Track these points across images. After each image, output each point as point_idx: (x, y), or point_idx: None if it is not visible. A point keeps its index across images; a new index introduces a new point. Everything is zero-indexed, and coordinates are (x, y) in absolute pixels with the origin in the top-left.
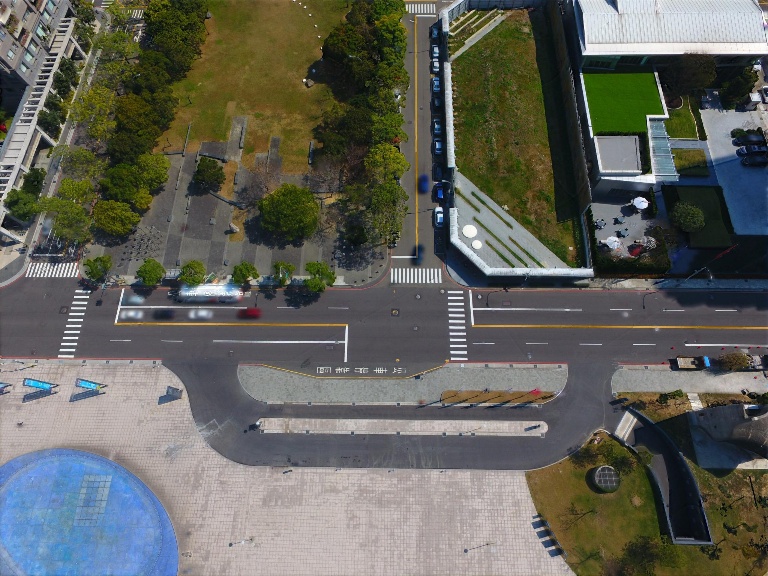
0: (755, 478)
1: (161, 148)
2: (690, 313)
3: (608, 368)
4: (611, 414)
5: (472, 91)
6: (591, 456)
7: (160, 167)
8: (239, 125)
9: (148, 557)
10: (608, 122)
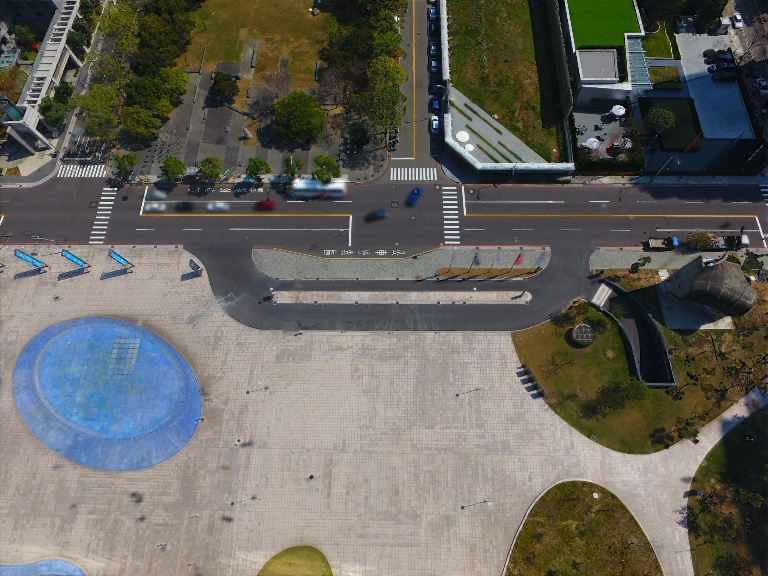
0: (716, 337)
1: (179, 68)
2: (662, 204)
3: (587, 249)
4: (589, 286)
5: (465, 18)
6: (570, 319)
7: (179, 80)
8: (251, 48)
9: (174, 403)
10: (589, 39)
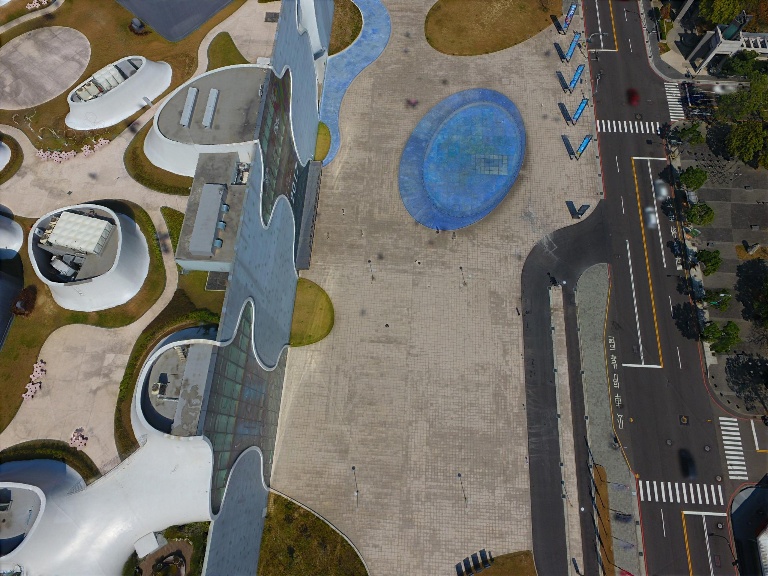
0: None
1: None
2: None
3: None
4: None
5: None
6: None
7: None
8: None
9: (451, 209)
10: None
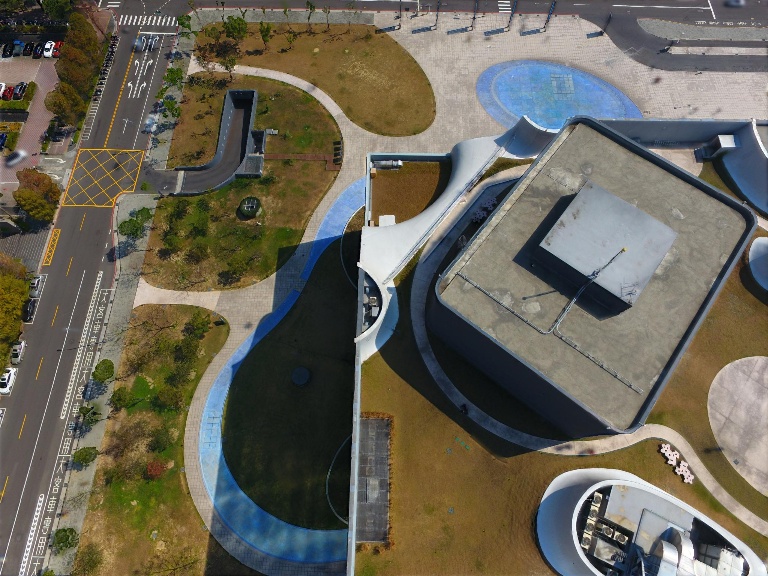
0: None
1: None
2: None
3: None
4: None
5: None
6: None
7: None
8: None
9: (618, 115)
10: None
